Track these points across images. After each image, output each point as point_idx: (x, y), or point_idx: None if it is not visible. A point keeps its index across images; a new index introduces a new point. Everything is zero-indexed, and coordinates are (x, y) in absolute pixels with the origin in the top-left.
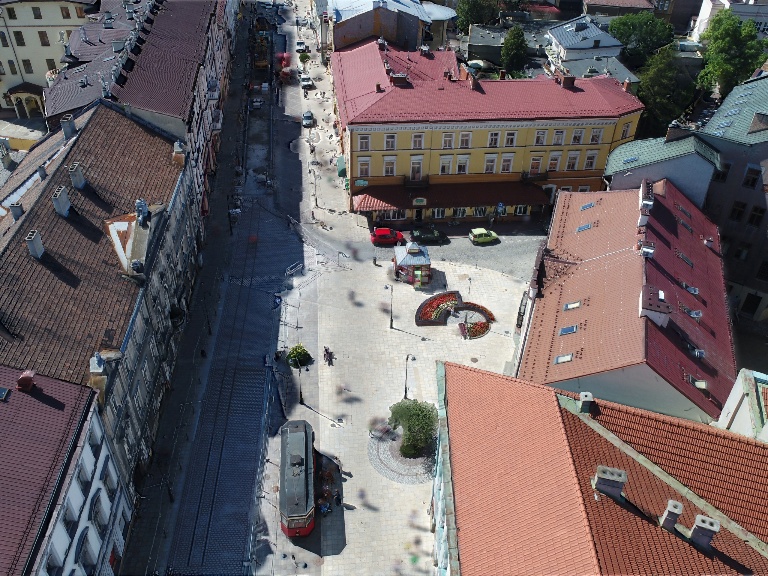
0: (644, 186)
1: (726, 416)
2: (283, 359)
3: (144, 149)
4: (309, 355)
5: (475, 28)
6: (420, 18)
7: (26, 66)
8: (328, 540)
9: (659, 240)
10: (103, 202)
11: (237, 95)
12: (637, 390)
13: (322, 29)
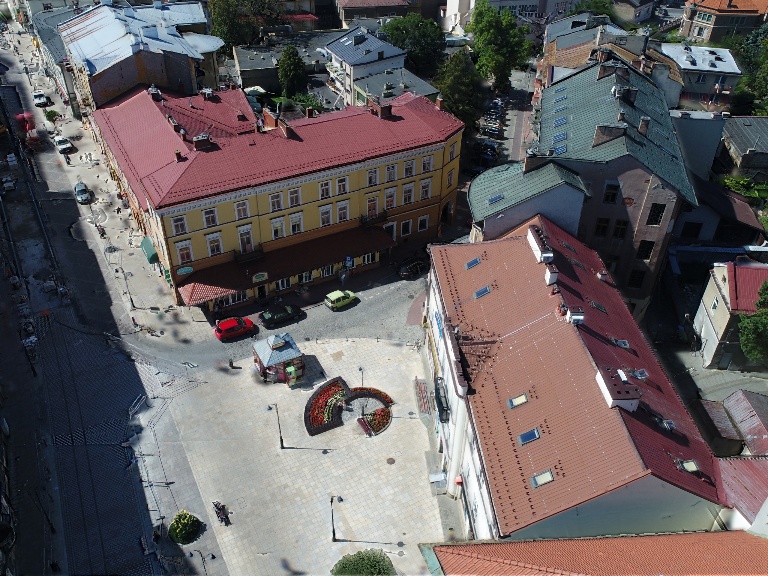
0: (536, 235)
1: (766, 523)
2: (165, 537)
3: None
4: (197, 520)
5: (240, 50)
6: (189, 55)
7: None
8: None
9: (572, 295)
10: None
11: None
12: (642, 501)
13: (65, 78)
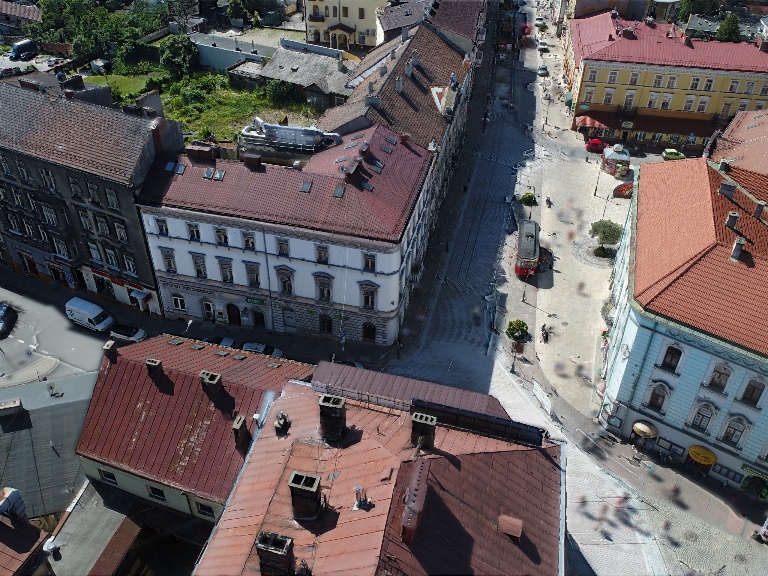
0: None
1: None
2: (518, 200)
3: (447, 55)
4: (536, 200)
5: (695, 17)
6: None
7: (344, 11)
8: (543, 282)
9: None
10: (427, 76)
11: (487, 50)
12: None
13: (562, 6)
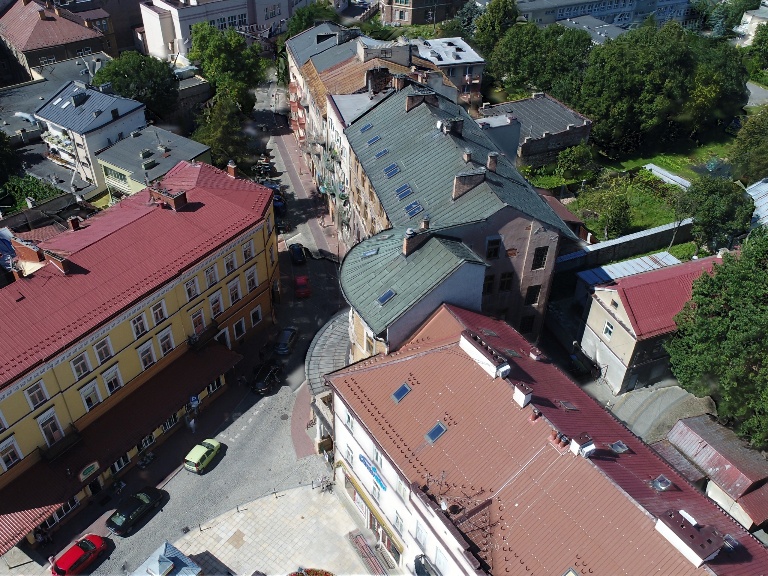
0: (478, 346)
1: None
2: None
3: None
4: None
5: None
6: None
7: None
8: None
9: (548, 408)
10: None
11: None
12: None
13: None
